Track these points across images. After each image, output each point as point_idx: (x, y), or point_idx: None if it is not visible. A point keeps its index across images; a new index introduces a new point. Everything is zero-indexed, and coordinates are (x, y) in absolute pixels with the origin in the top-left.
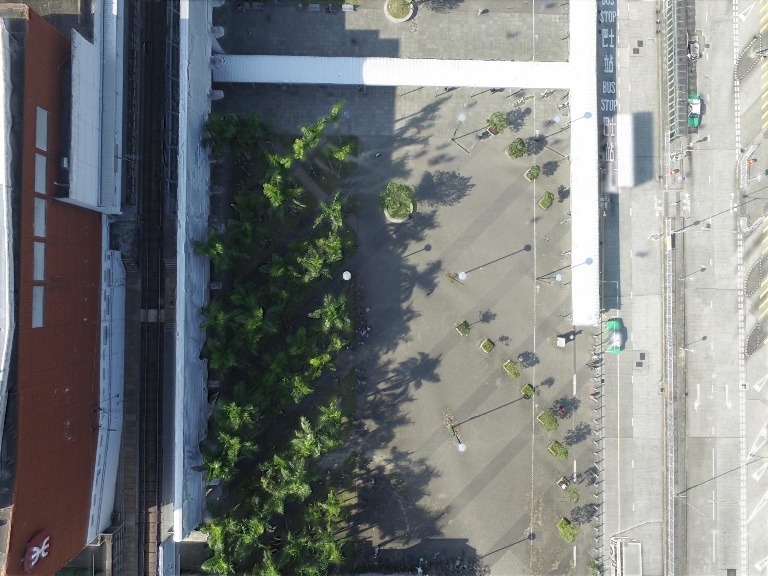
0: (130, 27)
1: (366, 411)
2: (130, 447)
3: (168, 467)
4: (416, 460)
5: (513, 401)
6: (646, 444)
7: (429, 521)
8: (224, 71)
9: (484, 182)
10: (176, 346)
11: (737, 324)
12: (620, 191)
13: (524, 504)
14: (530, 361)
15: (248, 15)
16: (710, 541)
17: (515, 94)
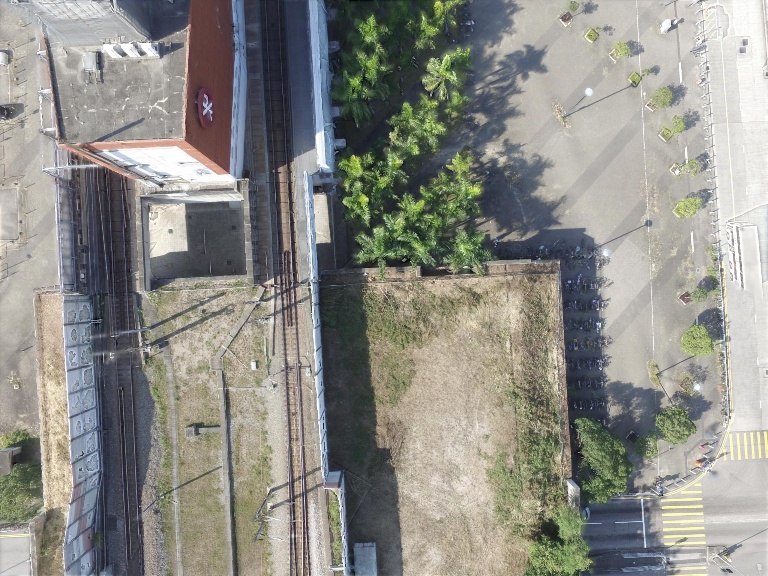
0: None
1: (475, 105)
2: (256, 106)
3: (298, 119)
4: (528, 152)
5: (621, 89)
6: (755, 128)
7: (545, 212)
8: None
9: None
10: None
11: None
12: None
13: (639, 191)
14: (635, 50)
15: None
16: None
17: None
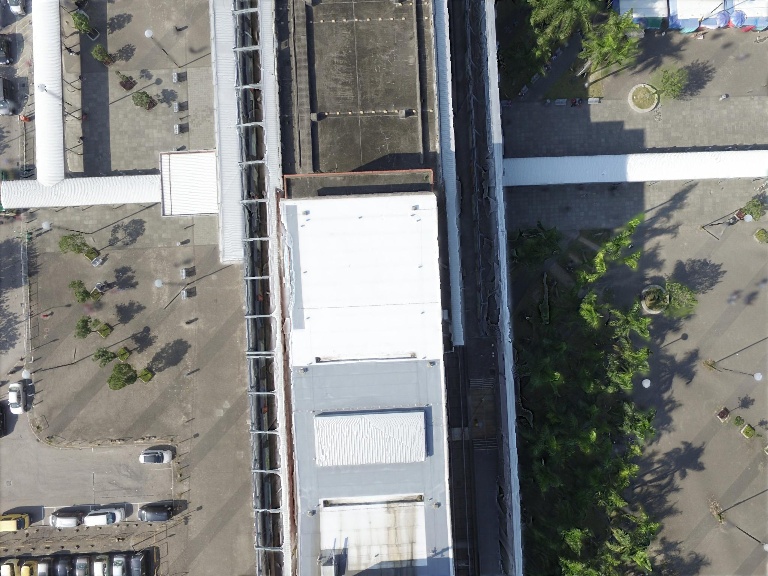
0: None
1: (634, 503)
2: None
3: None
4: (685, 549)
5: None
6: None
7: None
8: None
9: (735, 268)
10: None
11: None
12: None
13: None
14: None
15: None
16: None
17: (762, 179)
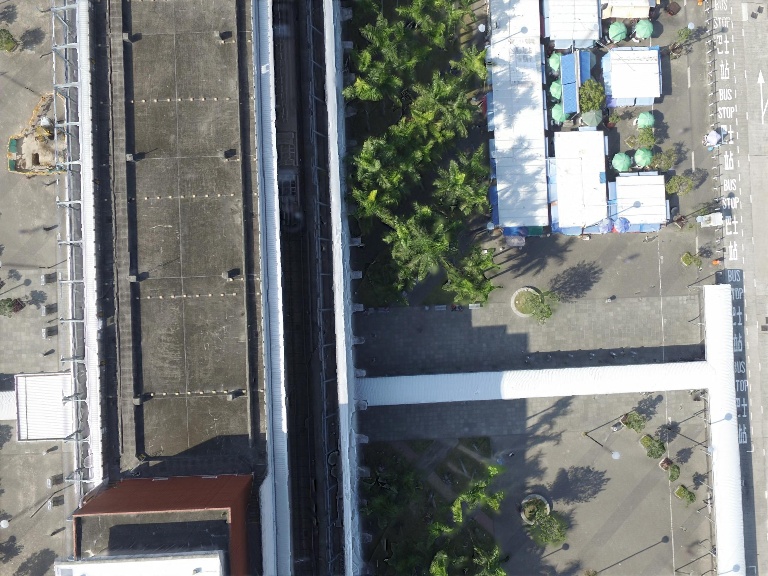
0: None
1: None
2: None
3: None
4: None
5: None
6: None
7: None
8: None
9: (619, 475)
10: None
11: None
12: (754, 474)
13: None
14: None
15: (372, 317)
16: None
17: None
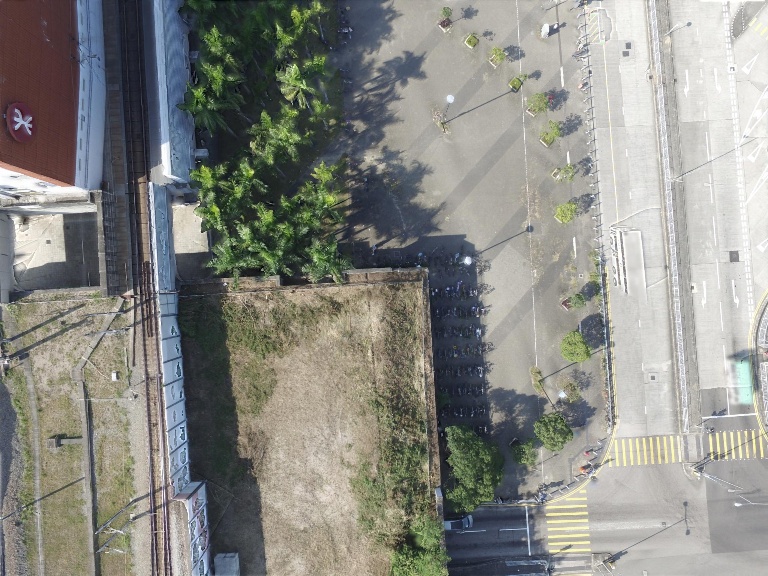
0: None
1: (354, 112)
2: (115, 117)
3: (154, 129)
4: (408, 158)
5: (501, 95)
6: (638, 132)
7: (425, 219)
8: None
9: None
10: None
11: (721, 8)
12: None
13: (520, 197)
14: (516, 55)
15: None
16: (710, 225)
17: None
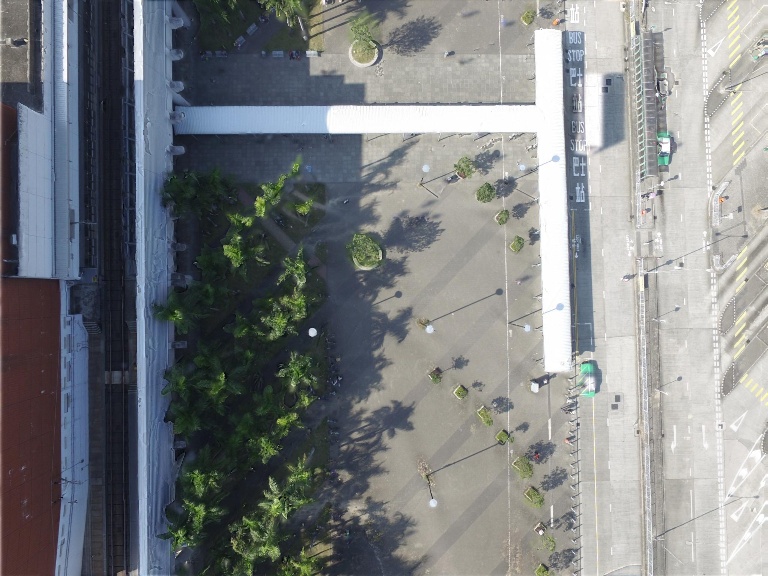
0: (86, 87)
1: (339, 461)
2: (96, 512)
3: (135, 532)
4: (391, 510)
5: (488, 447)
6: (623, 487)
7: (406, 571)
8: (186, 124)
9: (454, 226)
10: (138, 413)
11: (712, 363)
12: (591, 232)
13: (501, 551)
14: (504, 406)
15: (211, 63)
16: None
17: (483, 137)
